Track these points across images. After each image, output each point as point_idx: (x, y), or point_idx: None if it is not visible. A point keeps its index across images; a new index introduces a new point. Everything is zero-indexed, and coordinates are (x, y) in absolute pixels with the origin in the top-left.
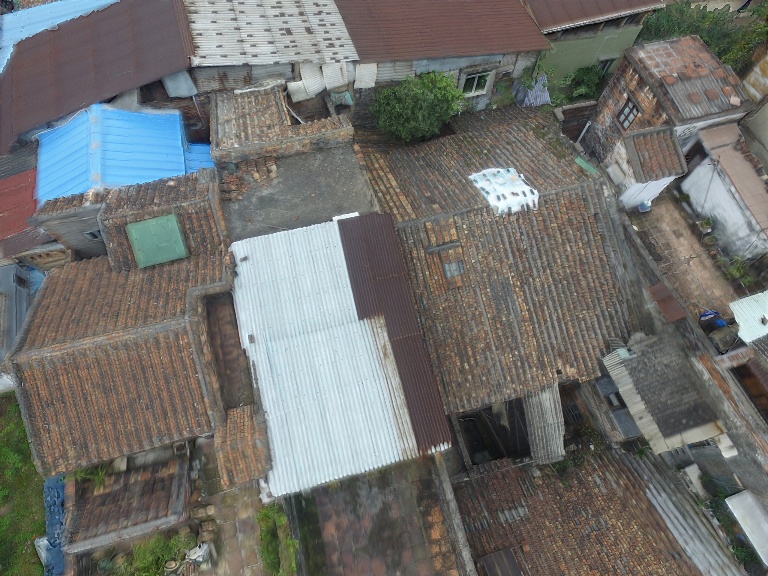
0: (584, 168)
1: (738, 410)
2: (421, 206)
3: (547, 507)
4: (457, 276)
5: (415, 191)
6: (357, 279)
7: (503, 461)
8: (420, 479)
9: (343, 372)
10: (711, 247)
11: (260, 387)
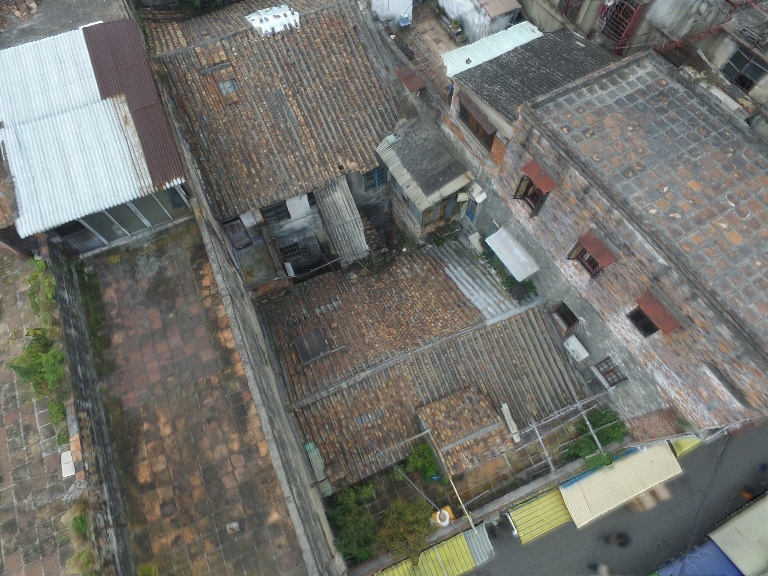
0: None
1: (473, 152)
2: (195, 40)
3: (358, 296)
4: (232, 92)
5: (195, 33)
6: (101, 70)
7: (325, 274)
8: (193, 245)
9: (87, 140)
10: None
11: (9, 159)
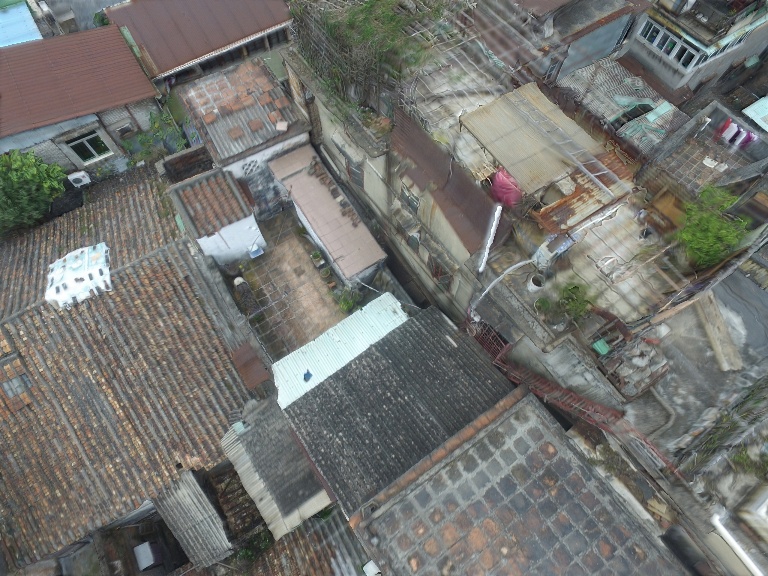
0: (178, 225)
1: None
2: None
3: None
4: (22, 393)
5: None
6: None
7: (187, 566)
8: None
9: None
10: (331, 279)
11: None
